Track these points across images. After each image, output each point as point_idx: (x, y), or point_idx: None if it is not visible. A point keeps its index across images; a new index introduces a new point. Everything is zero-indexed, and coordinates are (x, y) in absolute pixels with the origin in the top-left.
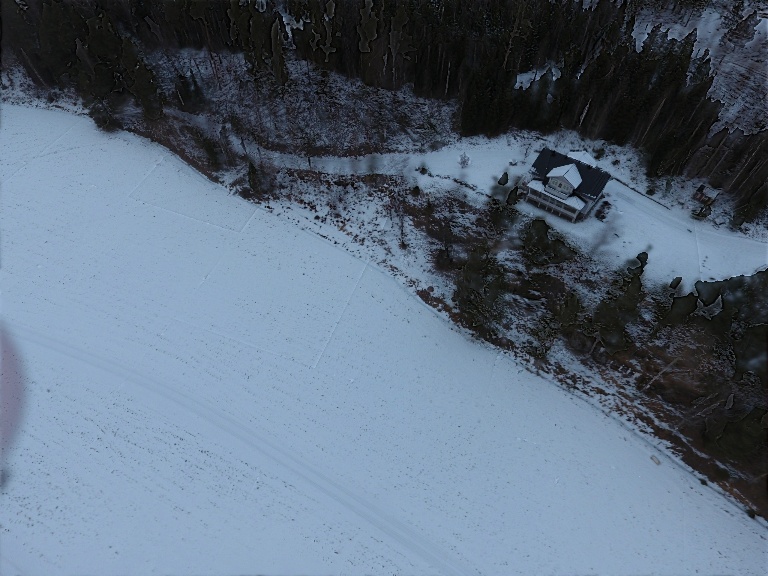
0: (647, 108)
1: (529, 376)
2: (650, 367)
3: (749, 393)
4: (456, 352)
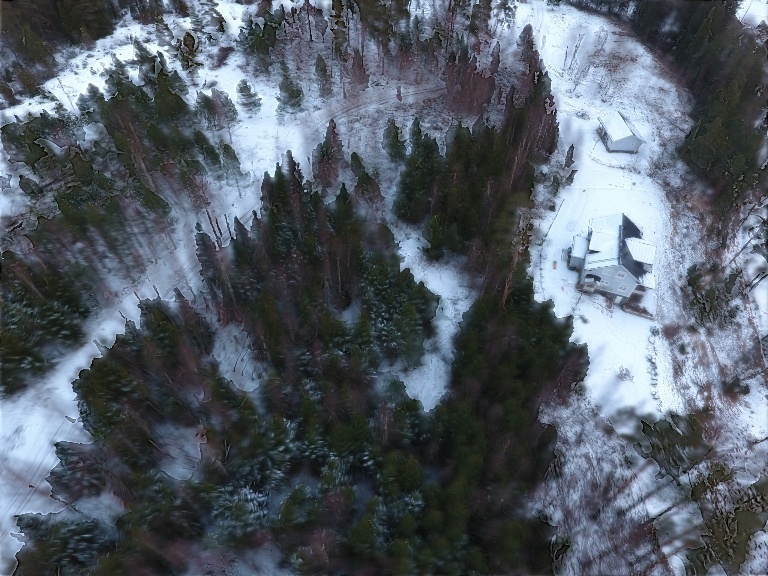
0: (497, 179)
1: (763, 307)
2: (712, 230)
3: (694, 187)
4: None
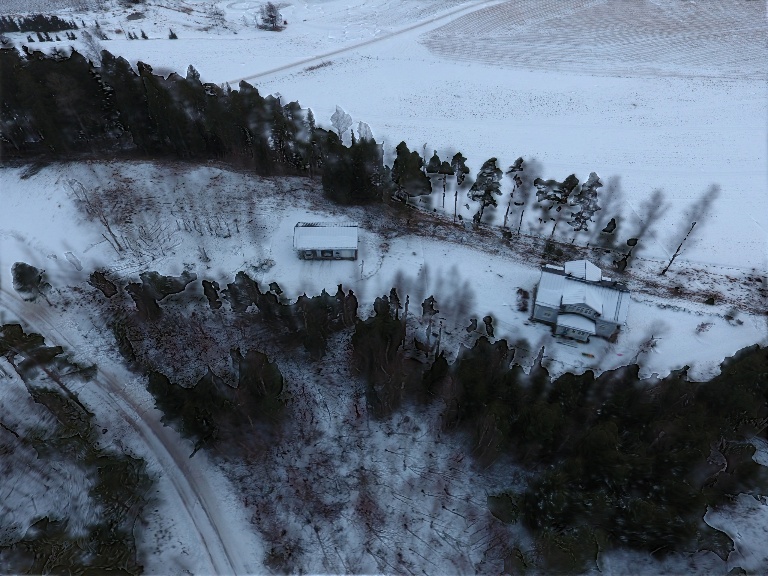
0: None
1: None
2: None
3: (384, 212)
4: (557, 227)
